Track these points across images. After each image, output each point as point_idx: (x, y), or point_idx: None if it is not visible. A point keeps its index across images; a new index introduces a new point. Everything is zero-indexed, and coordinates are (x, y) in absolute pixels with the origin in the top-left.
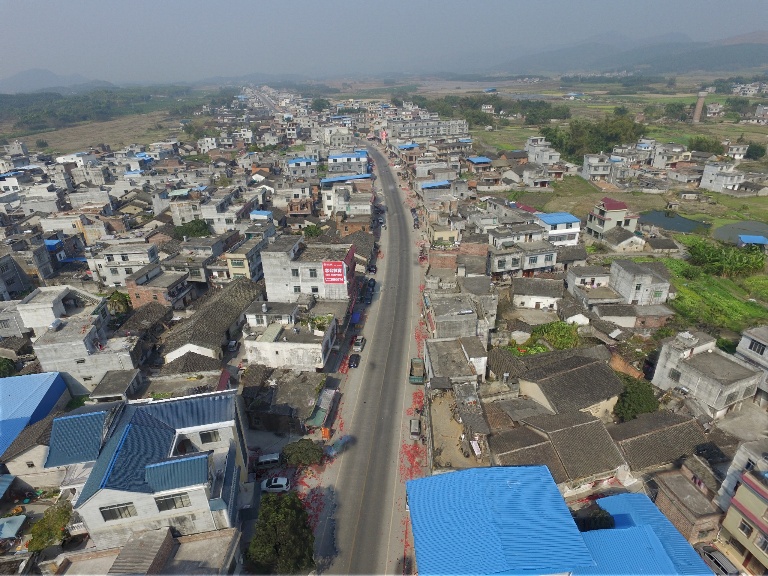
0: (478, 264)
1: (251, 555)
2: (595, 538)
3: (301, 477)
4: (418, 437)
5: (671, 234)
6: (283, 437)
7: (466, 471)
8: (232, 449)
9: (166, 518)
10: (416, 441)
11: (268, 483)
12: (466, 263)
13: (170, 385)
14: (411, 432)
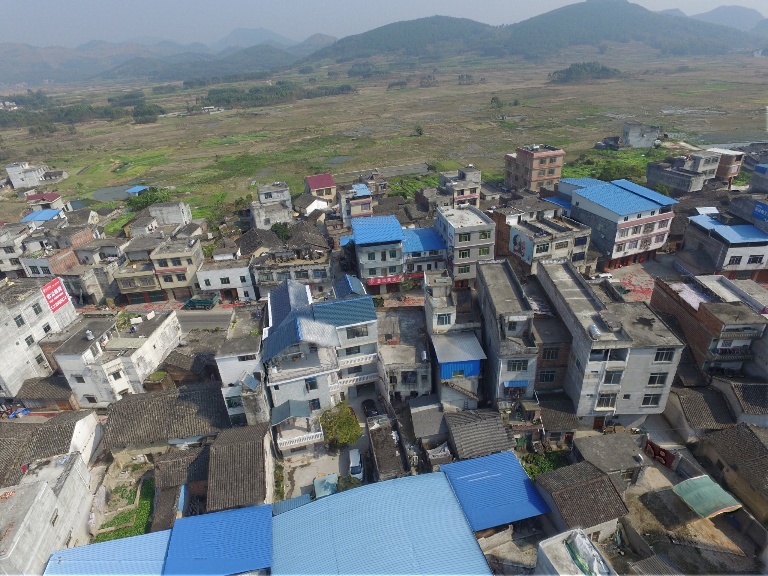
0: (106, 242)
1: None
2: None
3: None
4: None
5: None
6: None
7: (354, 229)
8: None
9: None
10: None
11: None
12: (98, 246)
13: (237, 336)
14: None
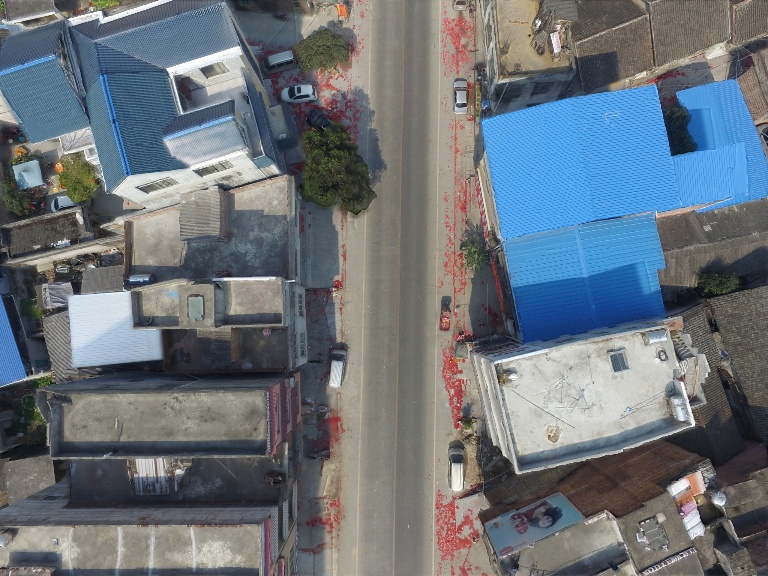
0: None
1: (309, 193)
2: (680, 163)
3: (326, 79)
4: (465, 7)
5: None
6: (286, 20)
7: (557, 104)
8: (249, 83)
9: (211, 180)
10: (461, 12)
11: (291, 93)
12: None
13: None
14: (456, 1)
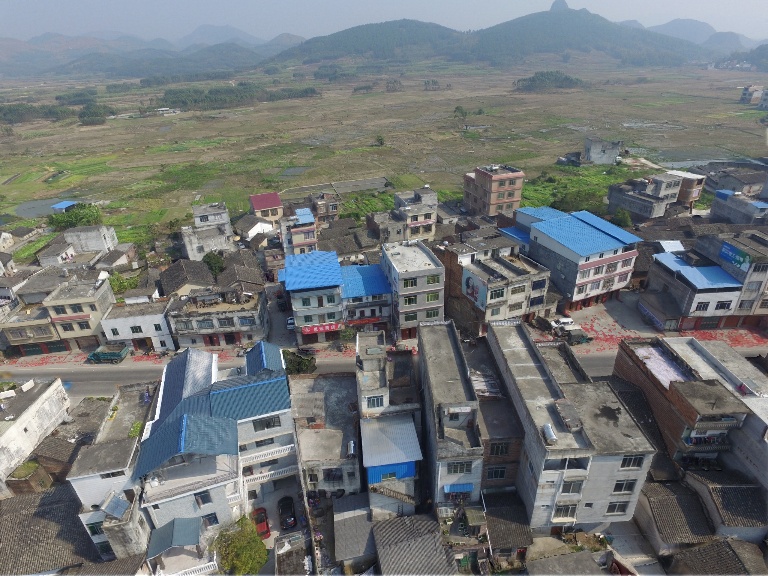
0: None
1: None
2: None
3: None
4: None
5: (0, 229)
6: None
7: (286, 271)
8: None
9: None
10: None
11: None
12: None
13: (114, 432)
14: None
